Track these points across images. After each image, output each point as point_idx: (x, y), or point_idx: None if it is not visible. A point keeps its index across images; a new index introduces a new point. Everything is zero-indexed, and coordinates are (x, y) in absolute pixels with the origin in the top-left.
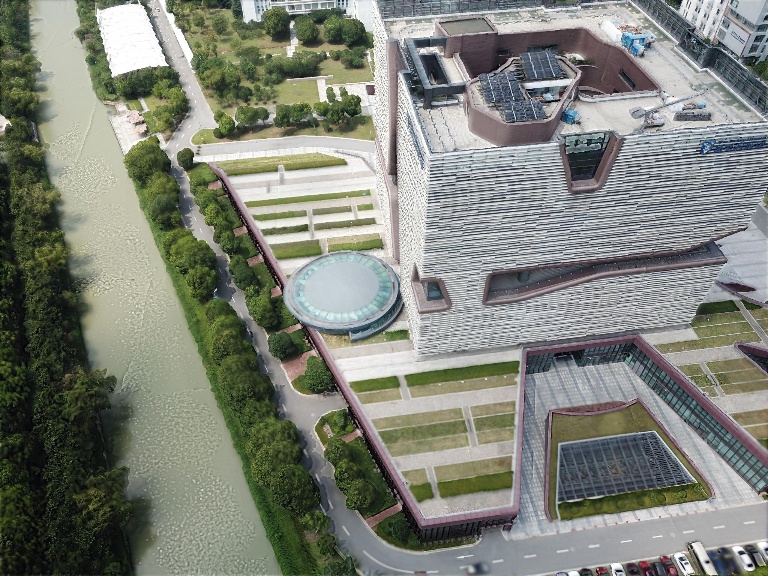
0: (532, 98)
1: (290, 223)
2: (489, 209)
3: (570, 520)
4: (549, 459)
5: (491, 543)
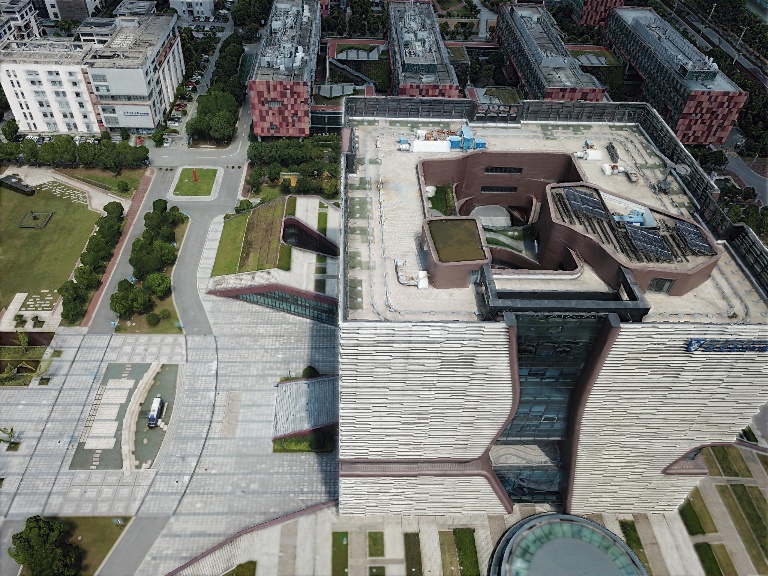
0: None
1: None
2: None
3: None
4: None
5: None
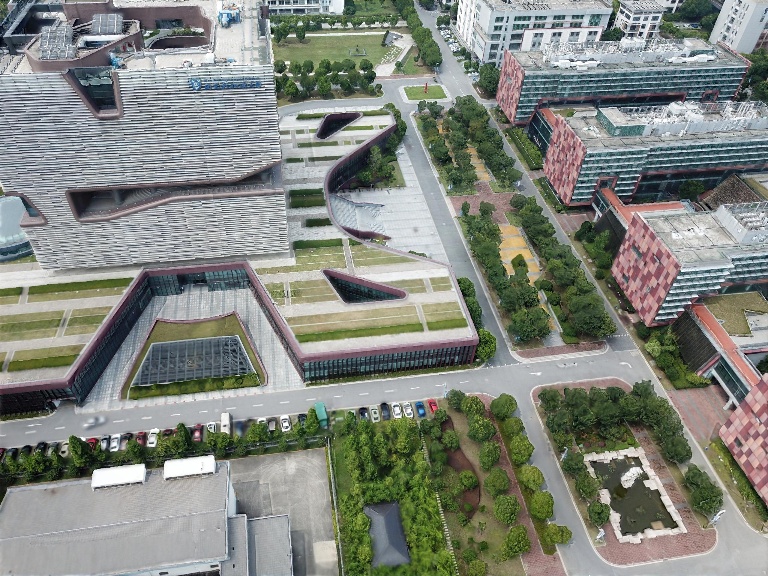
0: None
1: None
2: (32, 129)
3: (136, 399)
4: (138, 354)
5: (61, 416)
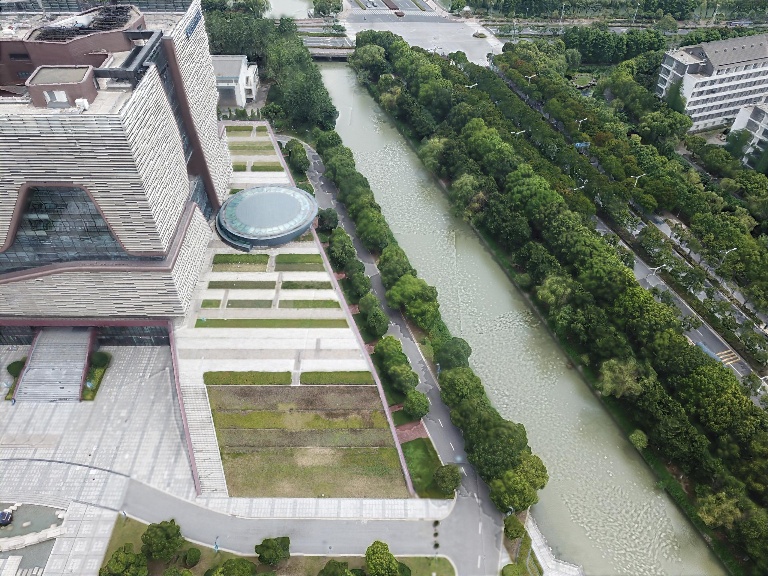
0: None
1: (300, 293)
2: None
3: None
4: None
5: None
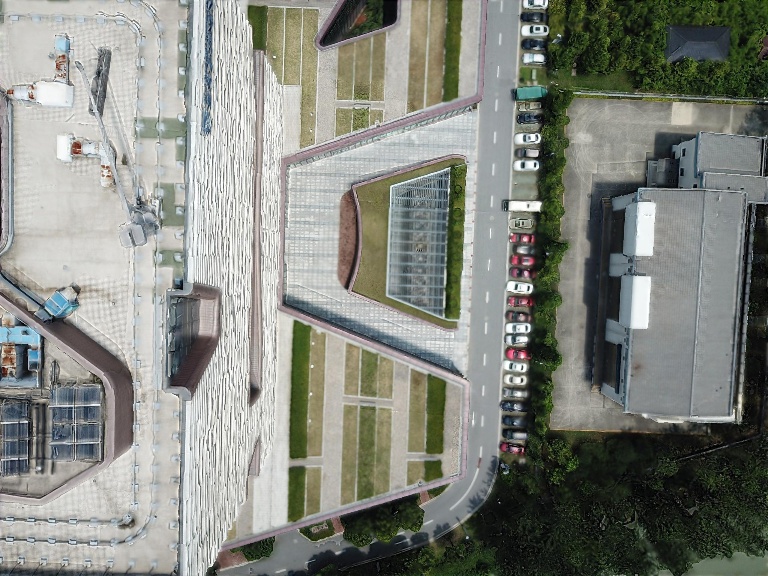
0: (5, 367)
1: None
2: None
3: (460, 311)
4: (401, 312)
5: None
